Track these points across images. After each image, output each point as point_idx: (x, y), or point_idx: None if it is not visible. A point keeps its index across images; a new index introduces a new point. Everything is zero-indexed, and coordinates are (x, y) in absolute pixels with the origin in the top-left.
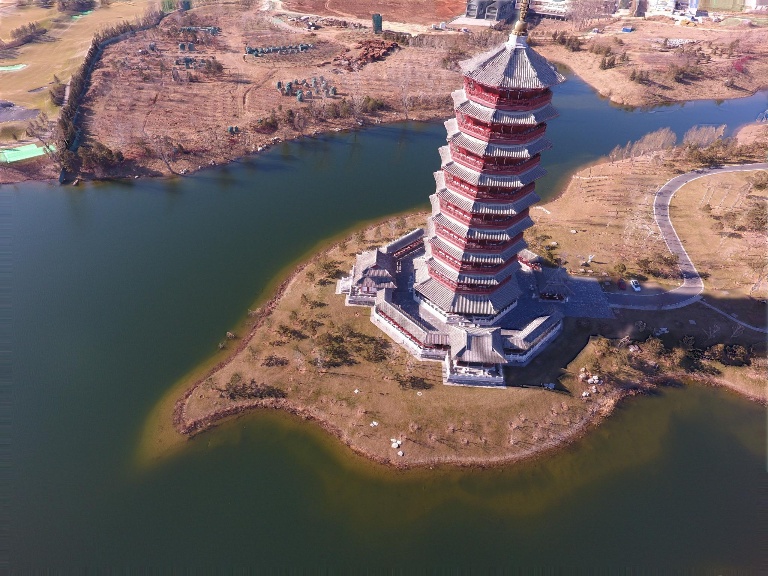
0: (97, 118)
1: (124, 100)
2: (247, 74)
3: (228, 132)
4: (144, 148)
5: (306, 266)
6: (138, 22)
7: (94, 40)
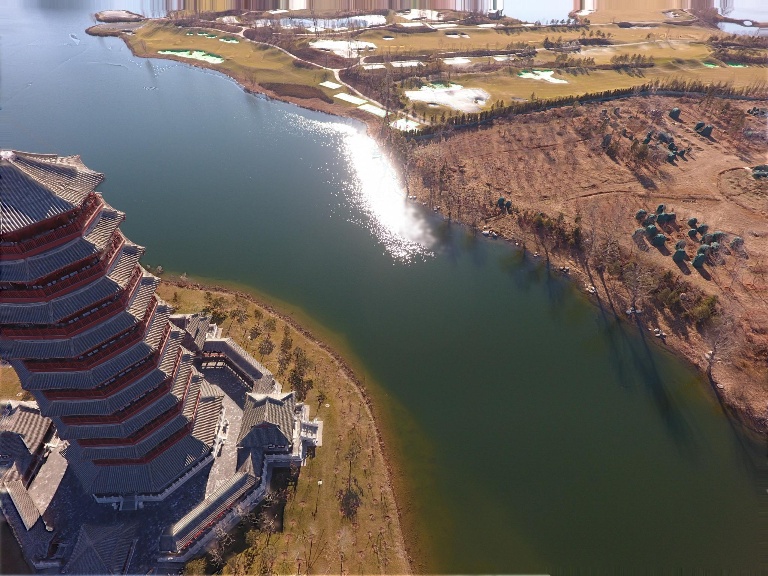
0: (479, 133)
1: (526, 134)
2: (675, 181)
3: (497, 200)
4: (434, 165)
5: (249, 300)
6: (729, 88)
7: (644, 85)
